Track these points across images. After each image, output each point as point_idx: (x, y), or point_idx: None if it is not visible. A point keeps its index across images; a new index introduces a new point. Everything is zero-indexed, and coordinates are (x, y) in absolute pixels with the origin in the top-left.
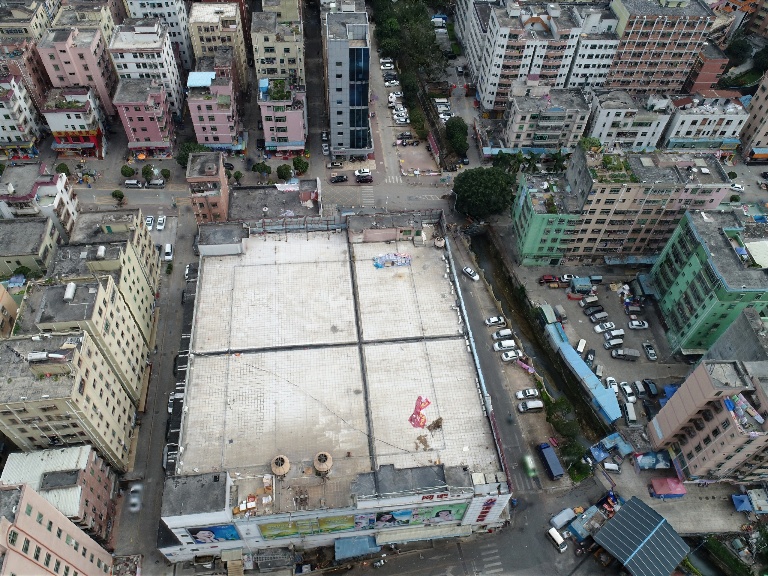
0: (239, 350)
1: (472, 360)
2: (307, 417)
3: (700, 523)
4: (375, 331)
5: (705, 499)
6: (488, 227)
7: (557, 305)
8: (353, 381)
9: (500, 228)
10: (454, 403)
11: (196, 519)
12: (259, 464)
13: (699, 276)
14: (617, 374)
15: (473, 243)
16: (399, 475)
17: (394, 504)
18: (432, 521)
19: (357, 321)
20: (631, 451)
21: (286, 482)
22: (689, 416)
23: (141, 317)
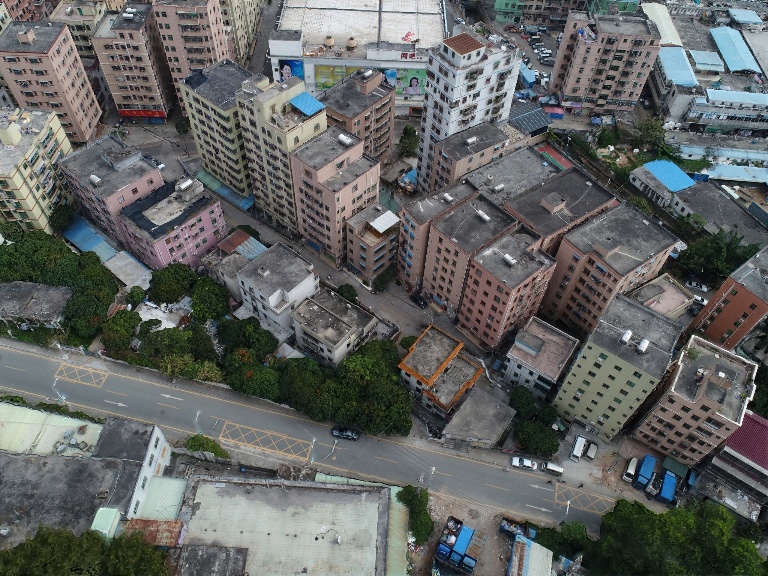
0: (311, 8)
1: (443, 23)
2: (345, 32)
3: (569, 129)
4: (390, 8)
5: (576, 121)
6: (478, 3)
7: (512, 37)
8: (373, 23)
9: (486, 4)
10: (428, 35)
11: (285, 48)
12: (318, 44)
13: (595, 2)
14: (541, 71)
15: (467, 13)
16: (391, 45)
17: (386, 59)
18: (408, 93)
19: (380, 4)
20: (536, 95)
21: (331, 50)
22: (563, 51)
23: (255, 3)
